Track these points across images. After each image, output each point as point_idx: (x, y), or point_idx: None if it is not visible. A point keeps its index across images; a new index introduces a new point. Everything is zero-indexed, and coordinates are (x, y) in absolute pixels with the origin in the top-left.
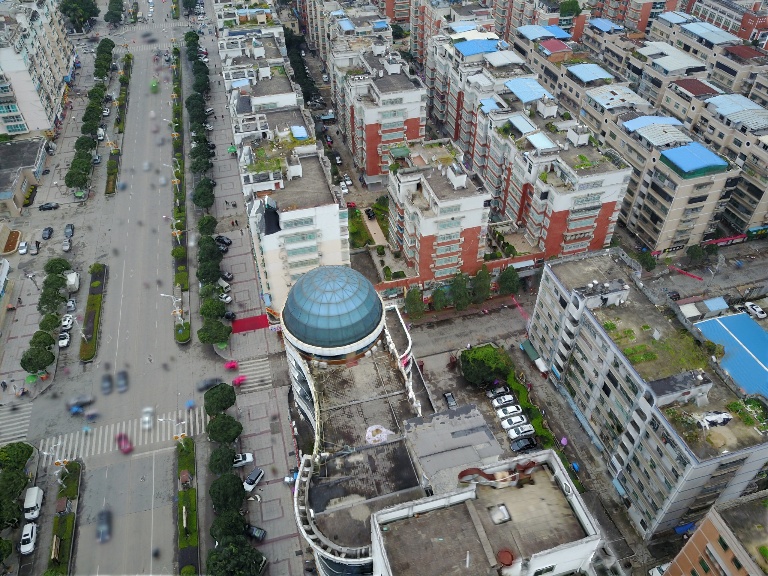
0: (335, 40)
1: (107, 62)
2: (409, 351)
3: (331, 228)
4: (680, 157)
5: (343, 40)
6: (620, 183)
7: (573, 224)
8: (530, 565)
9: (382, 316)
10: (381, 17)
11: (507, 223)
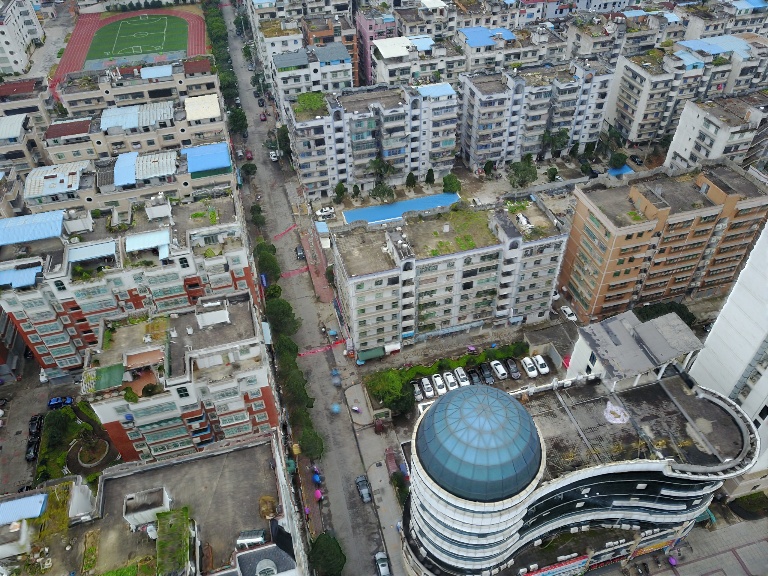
0: None
1: None
2: None
3: None
4: (205, 163)
5: None
6: None
7: None
8: None
9: None
10: None
11: None
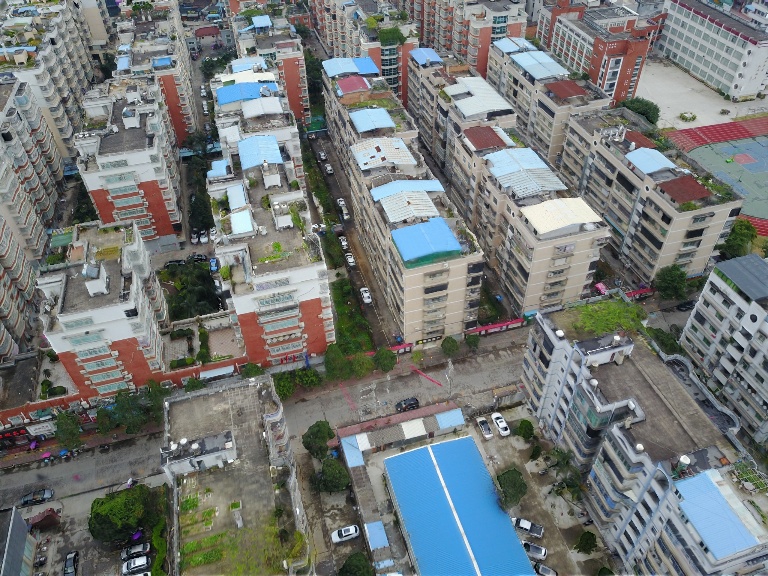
0: (98, 83)
1: None
2: None
3: None
4: (407, 239)
5: (106, 83)
6: (315, 279)
7: (268, 326)
8: None
9: None
10: (168, 52)
11: (225, 314)
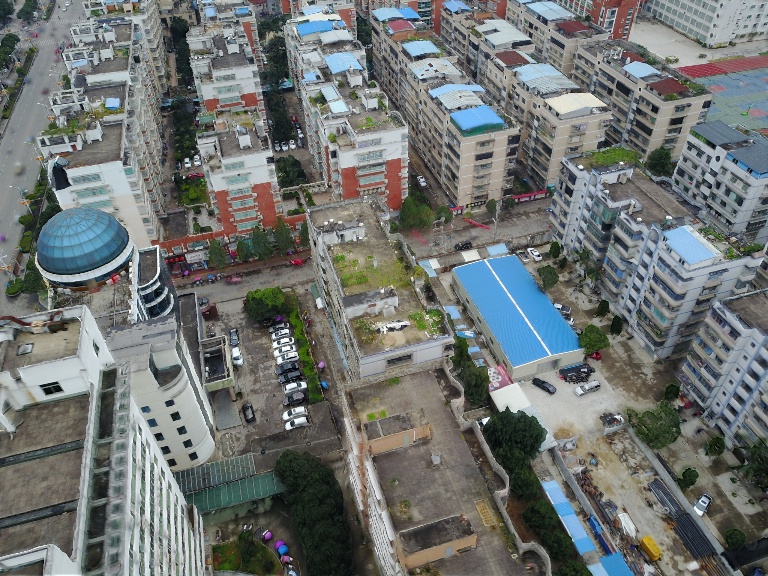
0: None
1: (7, 55)
2: (154, 281)
3: (120, 184)
4: (463, 118)
5: (201, 25)
6: (399, 141)
7: (363, 180)
8: (22, 378)
9: (124, 250)
10: (245, 4)
11: (320, 184)
